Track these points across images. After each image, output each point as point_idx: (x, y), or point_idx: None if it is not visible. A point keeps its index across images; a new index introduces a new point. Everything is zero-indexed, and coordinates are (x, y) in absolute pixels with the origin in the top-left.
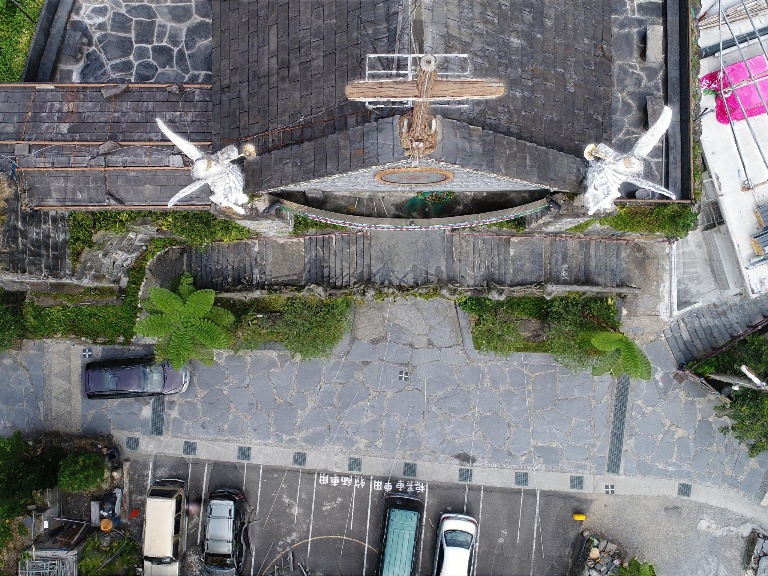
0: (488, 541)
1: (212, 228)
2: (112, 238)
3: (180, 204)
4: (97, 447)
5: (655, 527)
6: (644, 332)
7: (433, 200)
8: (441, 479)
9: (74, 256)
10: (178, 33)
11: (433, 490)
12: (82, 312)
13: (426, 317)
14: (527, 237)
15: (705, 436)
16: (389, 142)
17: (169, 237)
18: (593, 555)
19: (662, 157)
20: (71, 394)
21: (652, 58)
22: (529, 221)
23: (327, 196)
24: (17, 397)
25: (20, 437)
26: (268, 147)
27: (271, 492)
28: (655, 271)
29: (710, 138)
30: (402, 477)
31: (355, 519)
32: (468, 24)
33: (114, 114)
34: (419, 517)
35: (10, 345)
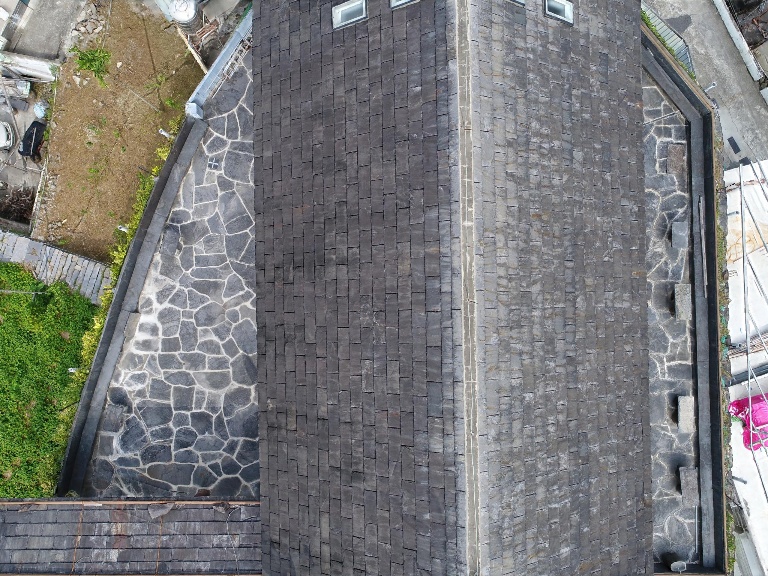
0: None
1: None
2: None
3: None
4: None
5: None
6: None
7: None
8: None
9: None
10: (216, 399)
11: None
12: None
13: None
14: None
15: None
16: None
17: None
18: None
19: (695, 519)
20: None
21: (684, 429)
22: None
23: None
24: None
25: None
26: None
27: None
28: None
29: (738, 464)
30: None
31: None
32: (522, 568)
33: (162, 538)
34: None
35: None
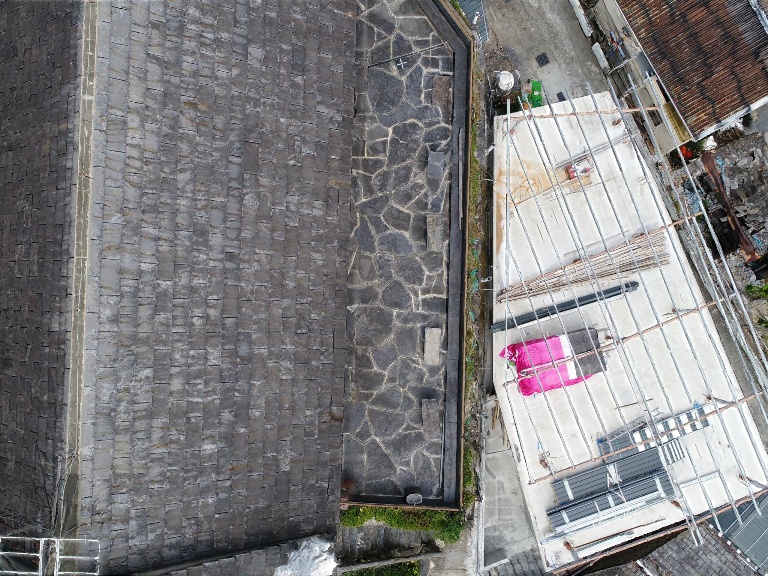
0: None
1: None
2: None
3: None
4: None
5: None
6: None
7: None
8: None
9: None
10: None
11: None
12: None
13: None
14: None
15: None
16: None
17: None
18: None
19: (441, 454)
20: None
21: (429, 361)
22: None
23: None
24: None
25: None
26: None
27: None
28: None
29: None
30: None
31: None
32: (143, 455)
33: None
34: None
35: None
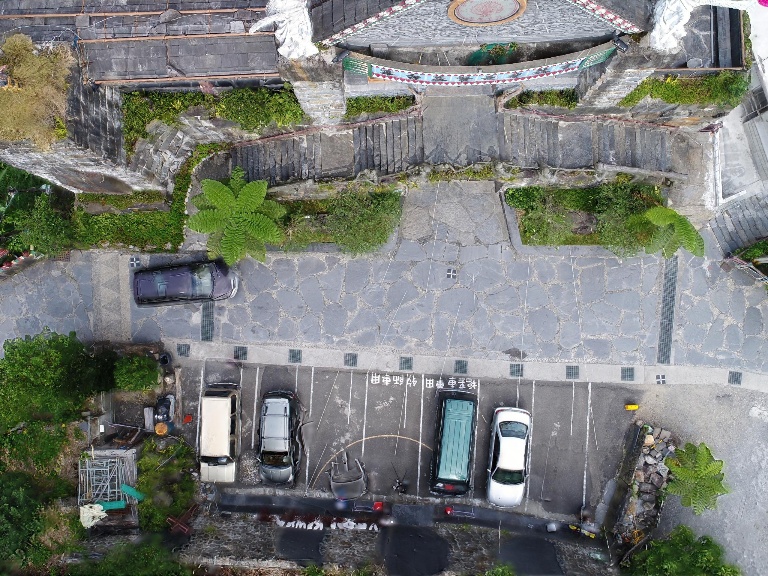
0: (541, 435)
1: (266, 111)
2: (163, 133)
3: (241, 73)
4: (149, 352)
5: (707, 415)
6: (690, 222)
7: (497, 52)
8: (492, 375)
9: (129, 145)
10: None
11: (485, 386)
12: (129, 220)
13: (472, 214)
14: (575, 121)
15: (754, 324)
16: None
17: (214, 143)
18: (648, 442)
19: (710, 30)
20: (120, 303)
21: None
22: (583, 91)
23: (391, 52)
24: (66, 308)
25: (76, 337)
26: None
27: (323, 394)
28: (699, 161)
29: (752, 21)
30: (453, 374)
31: (408, 417)
32: None
33: None
34: (474, 407)
35: (61, 250)
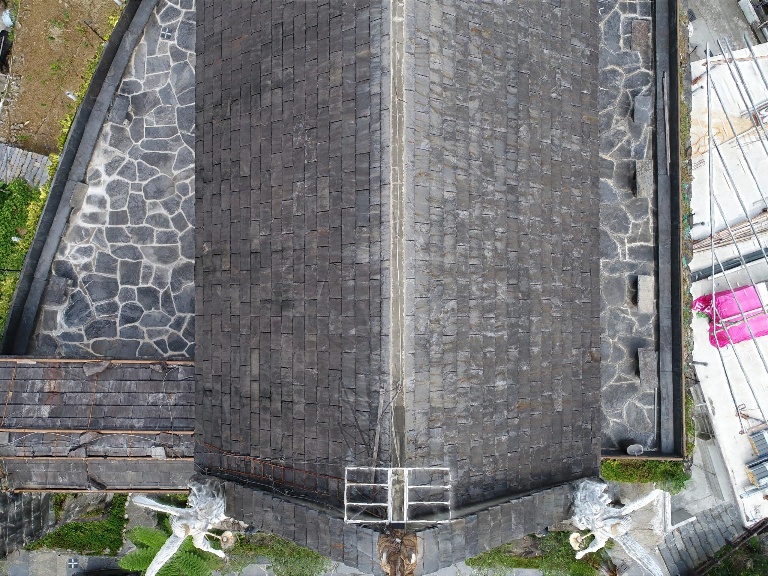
0: None
1: None
2: None
3: (163, 488)
4: None
5: None
6: None
7: None
8: None
9: (57, 507)
10: (164, 274)
11: None
12: (68, 525)
13: None
14: None
15: None
16: (368, 554)
17: None
18: None
19: (654, 404)
20: None
21: (643, 309)
22: None
23: None
24: None
25: None
26: (250, 472)
27: None
28: (649, 485)
29: (703, 361)
30: None
31: None
32: (452, 389)
33: (96, 395)
34: None
35: None
